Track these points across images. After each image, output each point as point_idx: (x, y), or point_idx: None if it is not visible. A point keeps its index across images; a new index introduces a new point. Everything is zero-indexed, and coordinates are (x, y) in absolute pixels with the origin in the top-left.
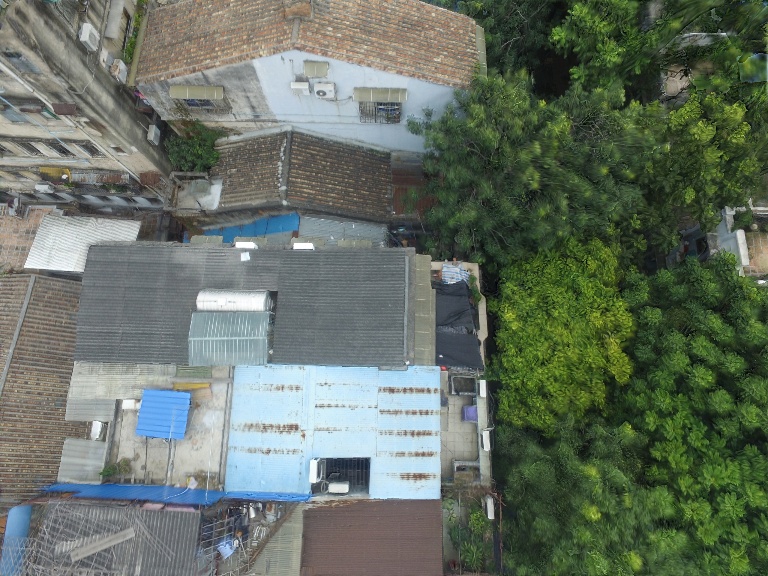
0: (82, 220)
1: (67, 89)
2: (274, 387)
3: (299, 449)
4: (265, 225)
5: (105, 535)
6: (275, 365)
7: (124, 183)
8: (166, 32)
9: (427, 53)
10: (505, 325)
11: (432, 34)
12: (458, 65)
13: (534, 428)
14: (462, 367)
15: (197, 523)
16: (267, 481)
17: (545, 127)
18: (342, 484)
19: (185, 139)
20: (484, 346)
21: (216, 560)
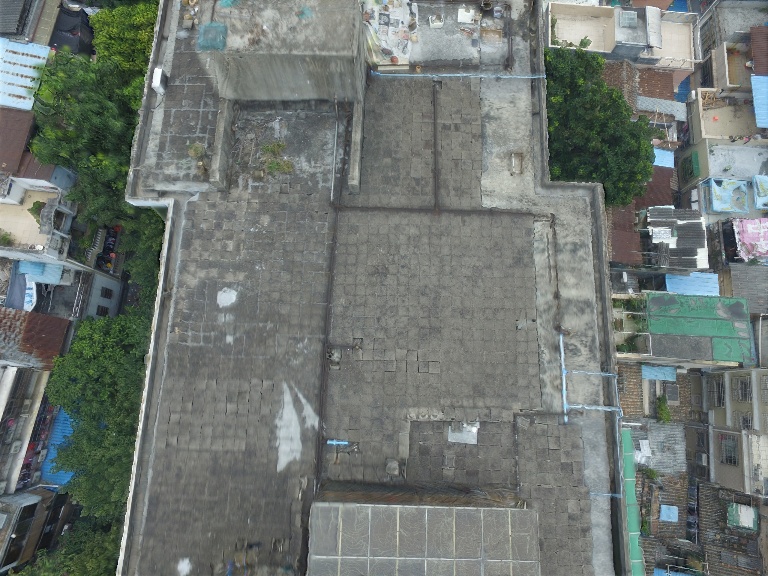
0: None
1: None
2: None
3: None
4: None
5: None
6: None
7: None
8: None
9: None
10: (89, 25)
11: None
12: None
13: None
14: (68, 52)
15: None
16: None
17: None
18: None
19: None
20: None
21: None
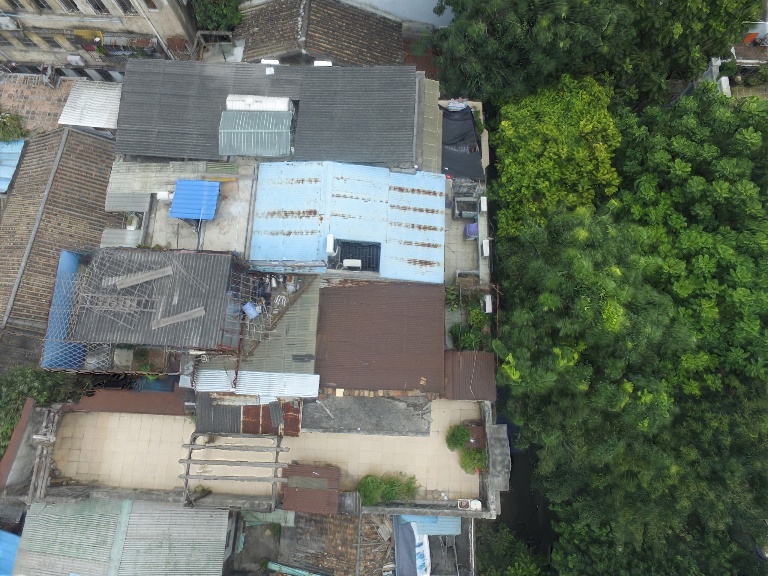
0: (112, 85)
1: None
2: (295, 181)
3: (317, 230)
4: None
5: (146, 272)
6: (296, 162)
7: (152, 48)
8: None
9: None
10: (505, 137)
11: None
12: None
13: None
14: (465, 179)
15: (228, 263)
16: (288, 257)
17: None
18: (355, 260)
19: (211, 1)
20: (486, 180)
21: None
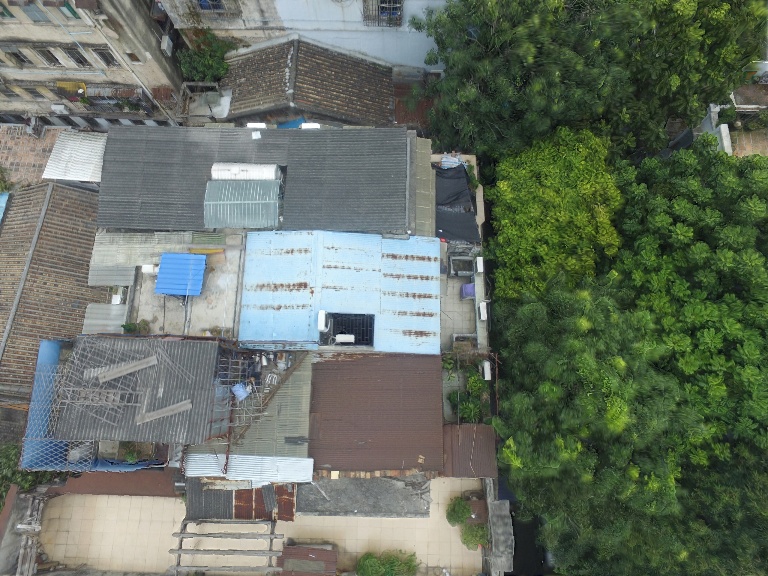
0: (97, 135)
1: None
2: (284, 251)
3: (308, 304)
4: None
5: (130, 362)
6: (285, 231)
7: (137, 98)
8: None
9: None
10: (501, 199)
11: None
12: None
13: (528, 301)
14: (460, 241)
15: (215, 351)
16: (278, 333)
17: (538, 5)
18: (348, 335)
19: (196, 51)
20: None
21: (231, 404)
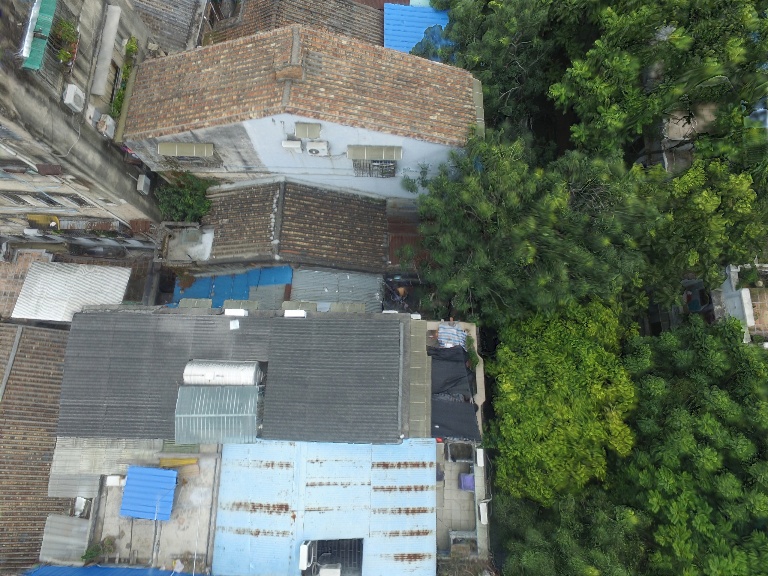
0: (71, 267)
1: (51, 153)
2: (264, 464)
3: (289, 531)
4: (258, 276)
5: None
6: (265, 440)
7: (114, 230)
8: (155, 87)
9: (423, 111)
10: (503, 396)
11: (428, 90)
12: (455, 122)
13: (533, 499)
14: (459, 438)
15: None
16: (256, 565)
17: (544, 196)
18: (334, 569)
19: (176, 188)
20: (482, 408)
21: None
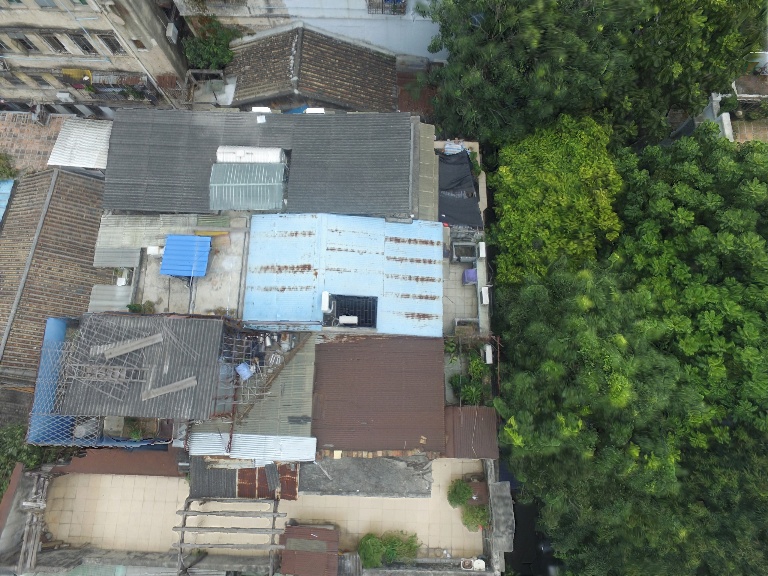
0: (102, 123)
1: None
2: (288, 234)
3: (312, 286)
4: None
5: (136, 339)
6: (289, 214)
7: (142, 86)
8: None
9: None
10: (503, 184)
11: None
12: None
13: None
14: (463, 226)
15: (220, 329)
16: (282, 314)
17: None
18: (351, 316)
19: (201, 39)
20: (484, 221)
21: (235, 383)
